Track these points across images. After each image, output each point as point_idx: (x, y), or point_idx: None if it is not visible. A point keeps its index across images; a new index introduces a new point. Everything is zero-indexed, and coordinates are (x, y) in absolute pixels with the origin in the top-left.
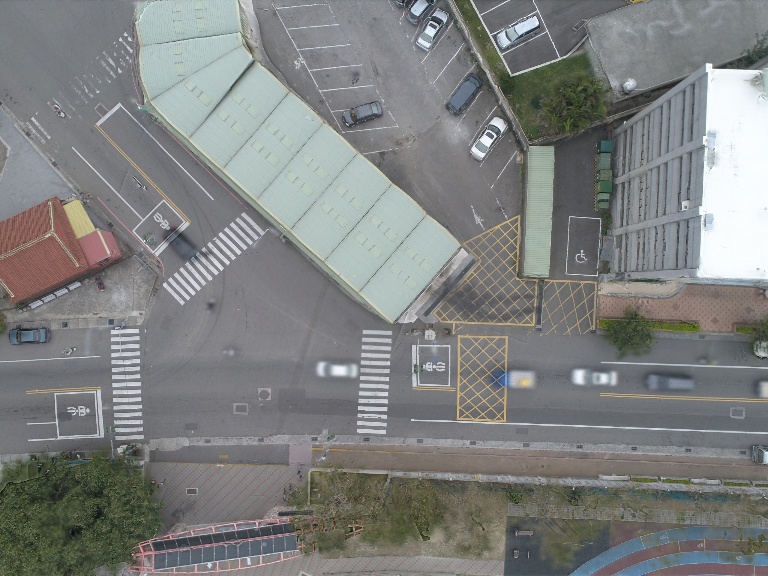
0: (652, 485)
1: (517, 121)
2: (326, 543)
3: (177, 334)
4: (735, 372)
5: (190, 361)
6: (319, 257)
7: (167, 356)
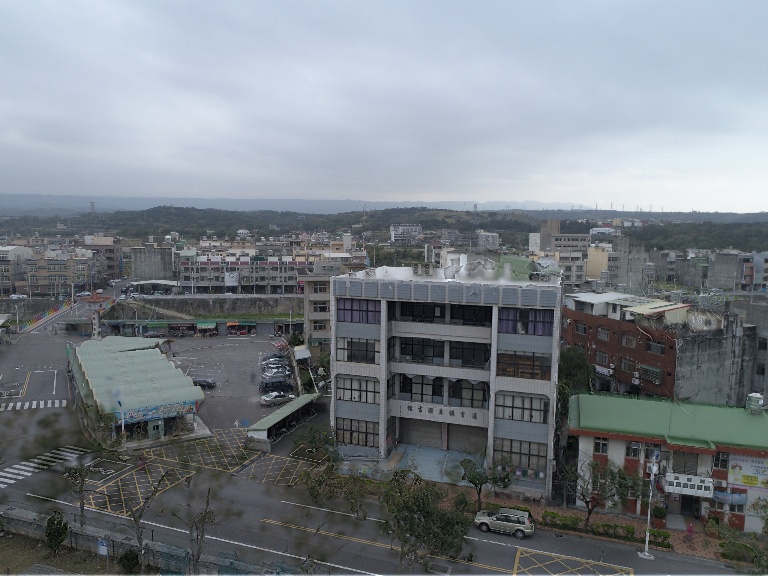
0: None
1: (303, 391)
2: None
3: None
4: None
5: None
6: (90, 387)
7: None
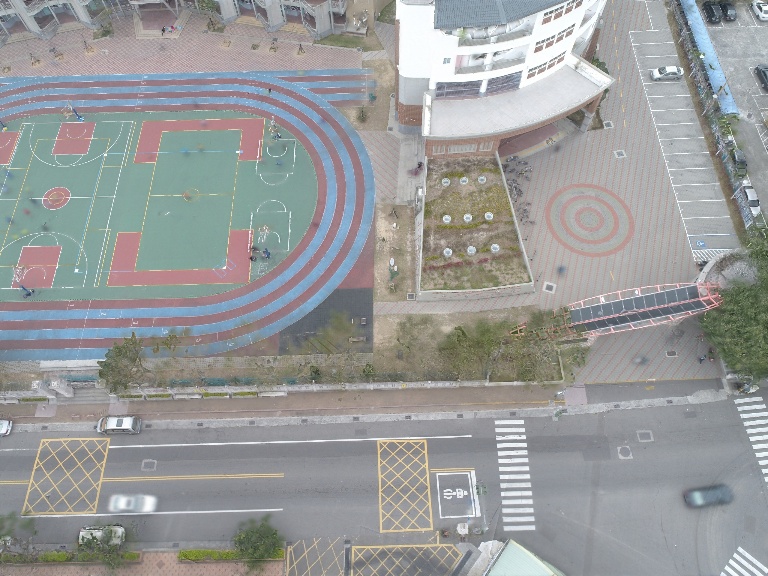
0: (240, 390)
1: None
2: (536, 318)
3: (735, 512)
4: (146, 508)
5: (712, 483)
6: None
7: (738, 487)
